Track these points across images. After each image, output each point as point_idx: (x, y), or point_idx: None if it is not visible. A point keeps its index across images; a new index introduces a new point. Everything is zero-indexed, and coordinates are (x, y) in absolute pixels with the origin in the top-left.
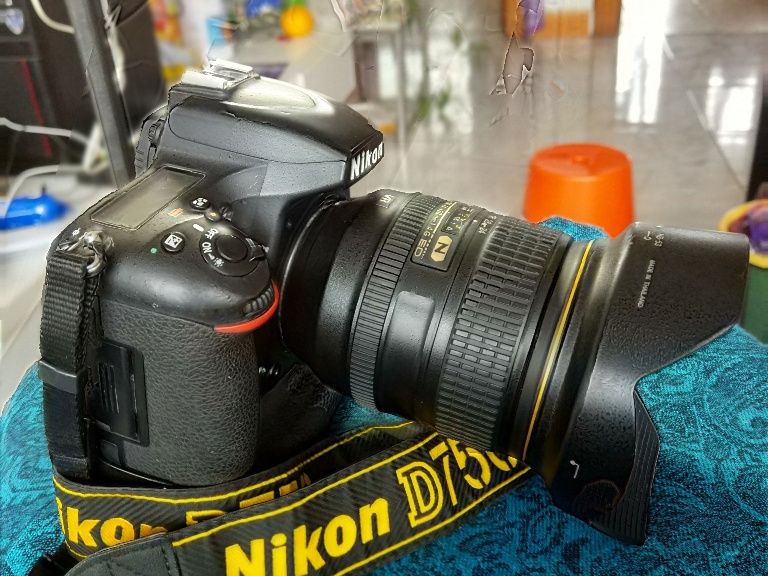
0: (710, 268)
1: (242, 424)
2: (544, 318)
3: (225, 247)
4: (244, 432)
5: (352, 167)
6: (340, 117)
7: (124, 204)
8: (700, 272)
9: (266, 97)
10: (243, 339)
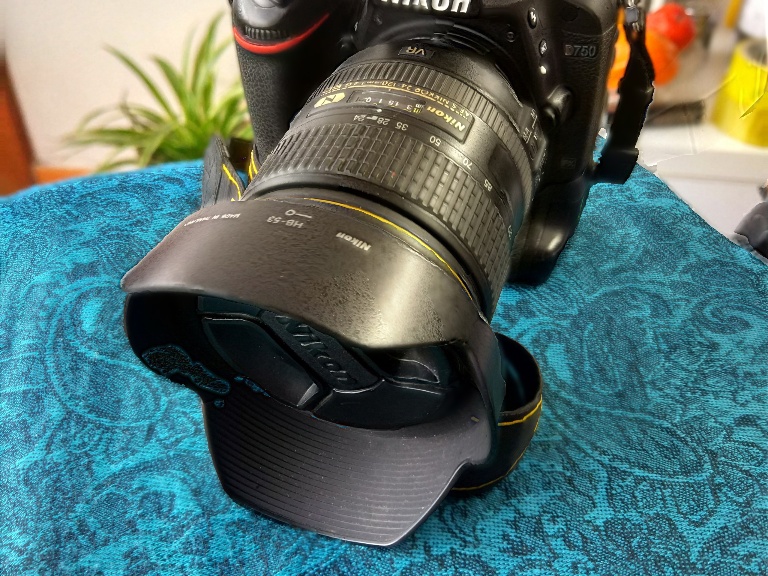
0: (206, 257)
1: (258, 127)
2: None
3: None
4: (262, 136)
5: None
6: None
7: None
8: (202, 250)
9: None
10: (259, 59)
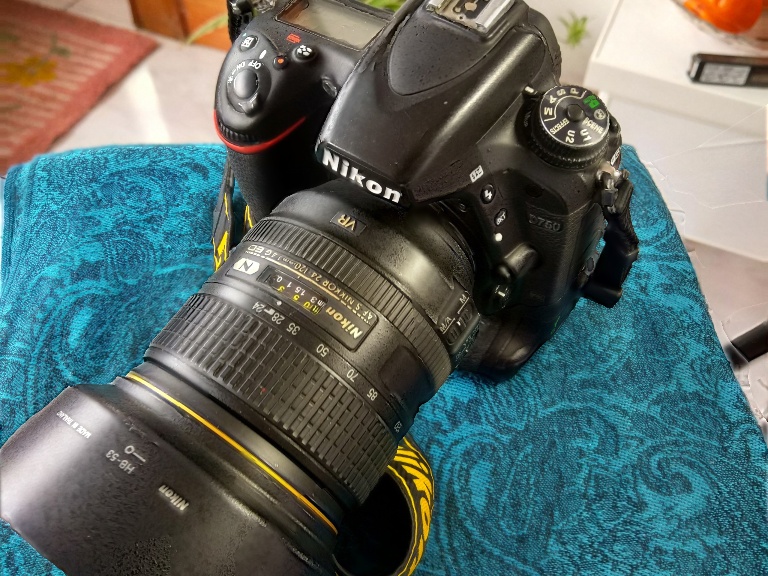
0: (40, 487)
1: None
2: (149, 363)
3: (243, 79)
4: None
5: (326, 155)
6: (383, 123)
7: (338, 11)
8: (43, 475)
9: (410, 46)
10: None
